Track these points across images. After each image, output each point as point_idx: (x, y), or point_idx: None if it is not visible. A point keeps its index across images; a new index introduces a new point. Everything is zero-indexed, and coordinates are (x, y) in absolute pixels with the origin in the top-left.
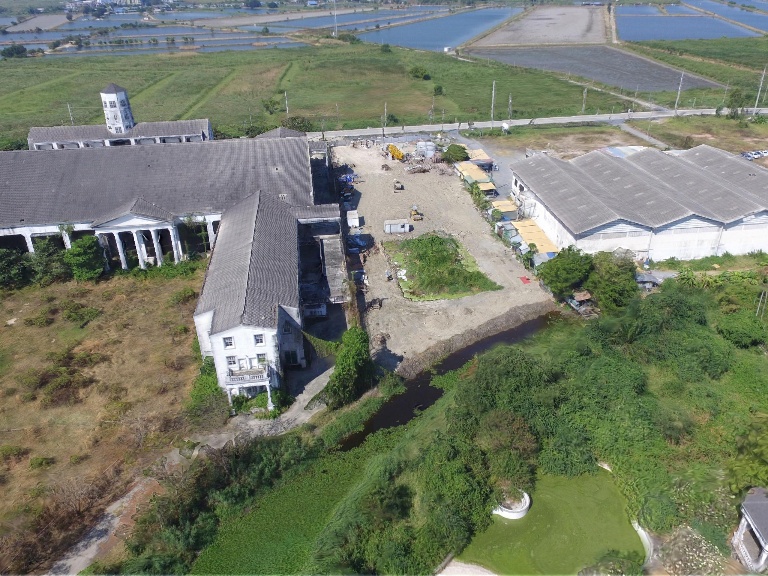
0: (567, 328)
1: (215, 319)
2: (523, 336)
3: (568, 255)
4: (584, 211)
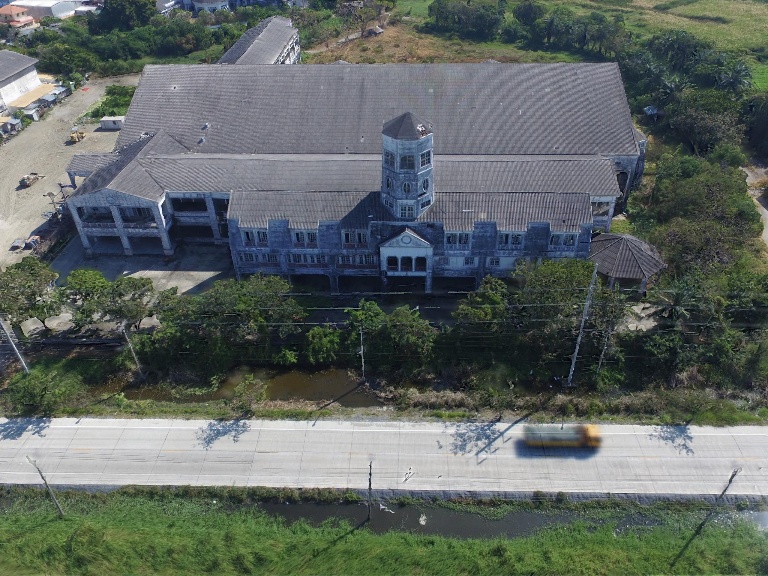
0: (115, 62)
1: (288, 23)
2: (135, 72)
3: (70, 54)
4: (6, 62)
